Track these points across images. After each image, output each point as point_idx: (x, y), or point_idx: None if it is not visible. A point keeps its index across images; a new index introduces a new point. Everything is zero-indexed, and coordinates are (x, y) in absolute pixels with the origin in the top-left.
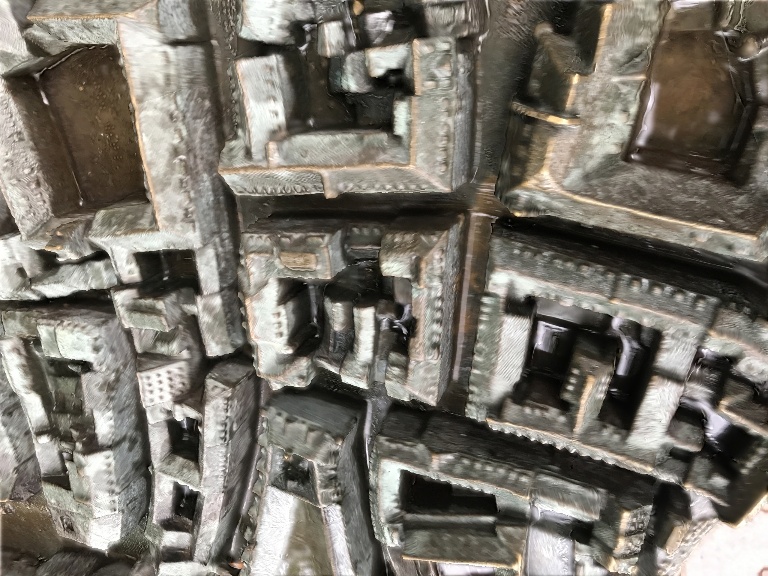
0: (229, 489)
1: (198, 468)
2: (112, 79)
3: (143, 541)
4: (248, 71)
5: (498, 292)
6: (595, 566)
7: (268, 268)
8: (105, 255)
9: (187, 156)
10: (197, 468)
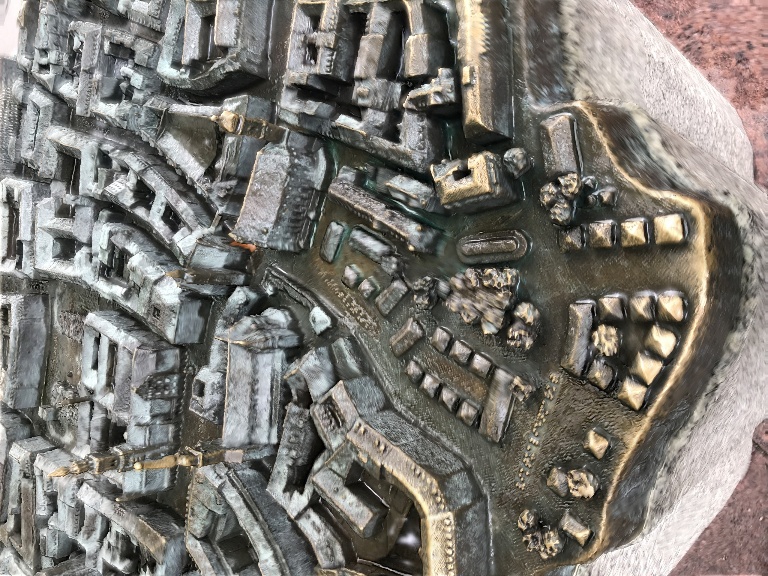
0: None
1: None
2: None
3: None
4: None
5: (125, 11)
6: None
7: None
8: None
9: None
10: (155, 195)
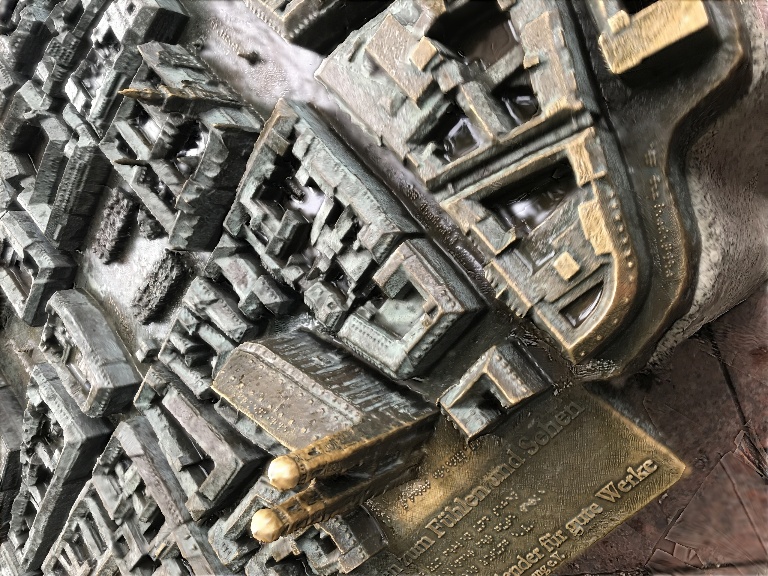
0: None
1: None
2: None
3: None
4: None
5: None
6: None
7: None
8: None
9: None
10: None
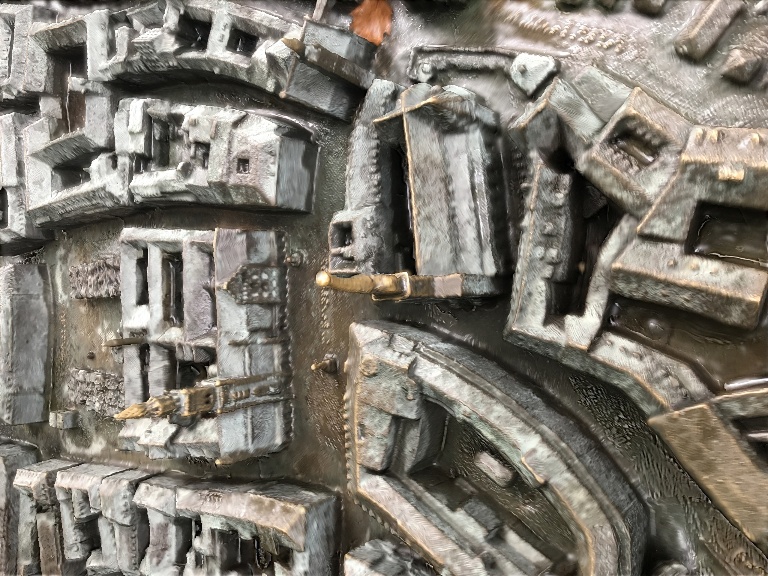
0: None
1: (211, 20)
2: None
3: (346, 157)
4: None
5: None
6: None
7: None
8: None
9: None
10: None
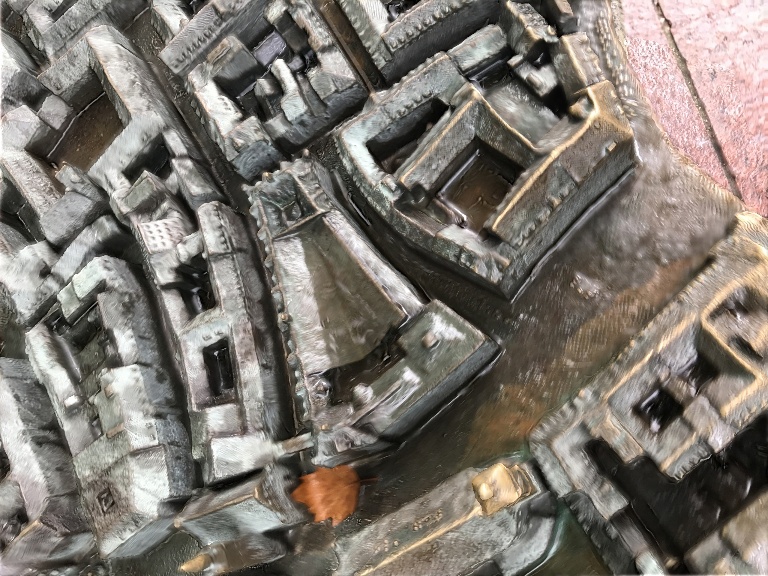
0: (257, 328)
1: (217, 304)
2: (96, 129)
3: None
4: (160, 8)
5: None
6: (540, 68)
7: (204, 76)
8: (105, 213)
9: (142, 85)
10: (216, 306)
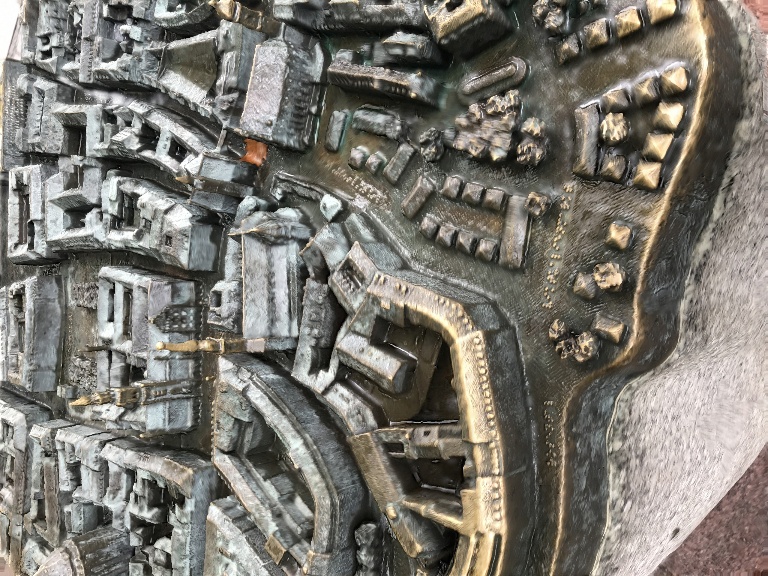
0: None
1: (160, 132)
2: None
3: None
4: None
5: None
6: None
7: None
8: None
9: None
10: None
